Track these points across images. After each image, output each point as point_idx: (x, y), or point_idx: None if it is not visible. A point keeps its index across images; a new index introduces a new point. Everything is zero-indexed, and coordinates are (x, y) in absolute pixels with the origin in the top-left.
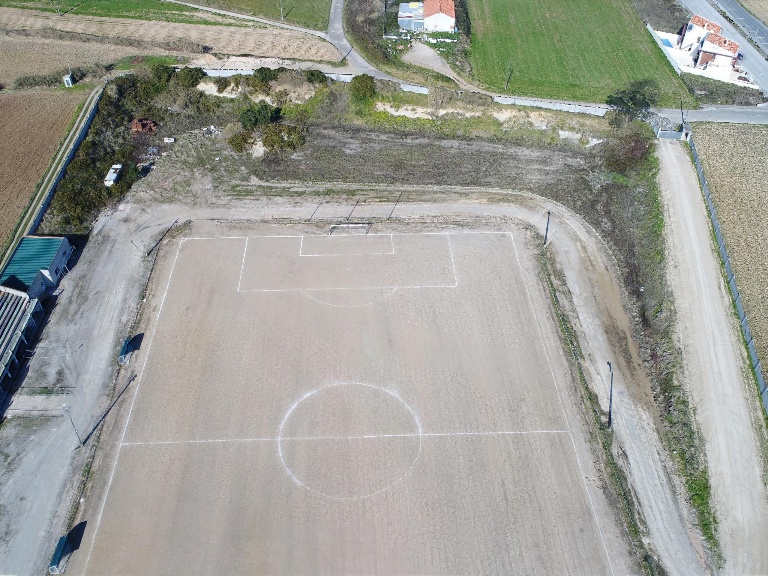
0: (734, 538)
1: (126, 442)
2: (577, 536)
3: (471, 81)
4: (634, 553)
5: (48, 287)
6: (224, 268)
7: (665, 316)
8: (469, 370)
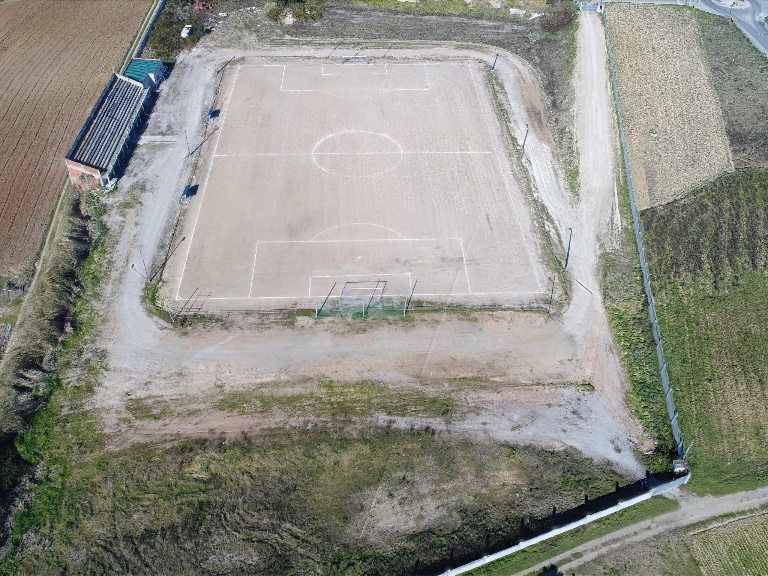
0: (589, 193)
1: (217, 155)
2: (495, 192)
3: None
4: (528, 199)
5: (152, 88)
6: (270, 80)
7: (567, 101)
8: (435, 126)
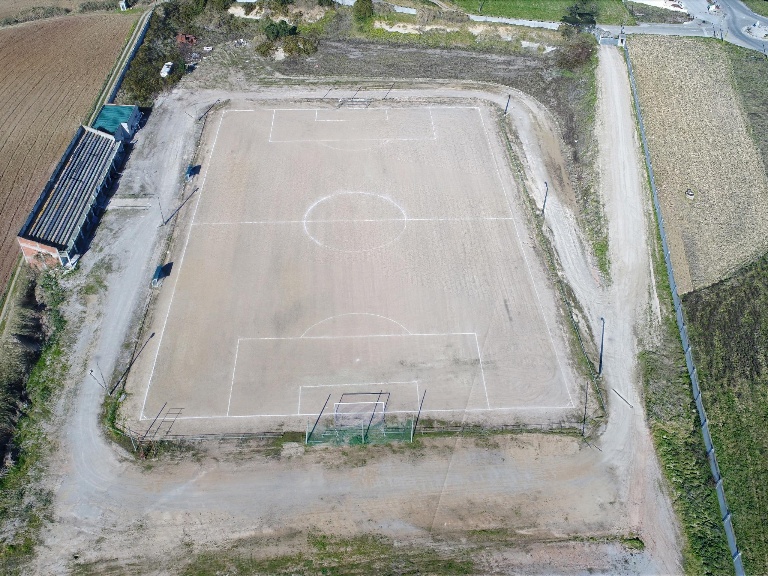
0: (621, 271)
1: (195, 223)
2: (513, 270)
3: (452, 5)
4: (551, 279)
5: (126, 138)
6: (258, 128)
7: (590, 154)
8: (442, 186)
